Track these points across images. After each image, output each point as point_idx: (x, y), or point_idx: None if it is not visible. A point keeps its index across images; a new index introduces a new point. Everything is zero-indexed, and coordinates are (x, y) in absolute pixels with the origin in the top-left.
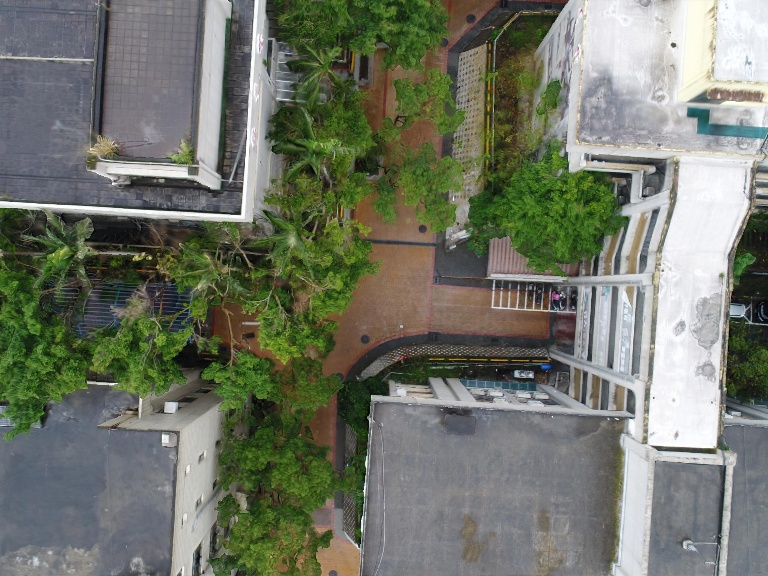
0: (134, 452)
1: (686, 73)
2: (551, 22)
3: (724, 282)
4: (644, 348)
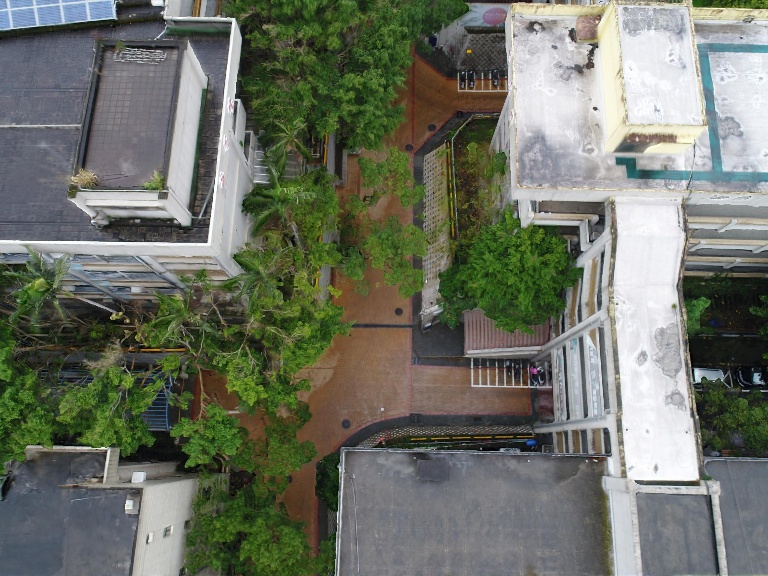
0: (96, 524)
1: (609, 128)
2: None
3: (677, 312)
4: (610, 380)
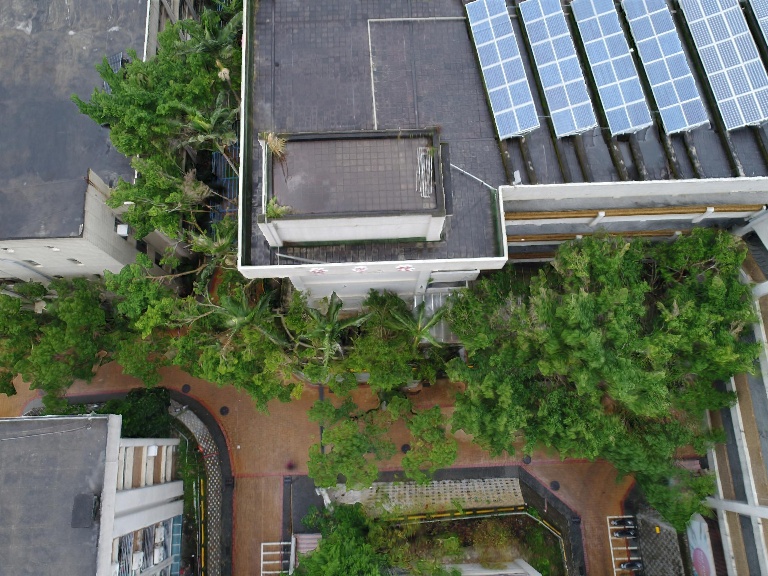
0: (77, 202)
1: None
2: (559, 574)
3: None
4: None
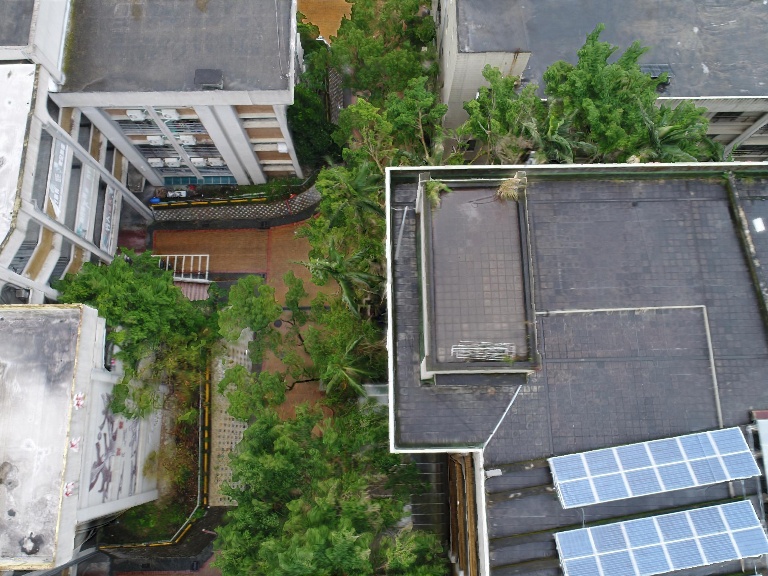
0: None
1: None
2: (139, 537)
3: None
4: (35, 147)
